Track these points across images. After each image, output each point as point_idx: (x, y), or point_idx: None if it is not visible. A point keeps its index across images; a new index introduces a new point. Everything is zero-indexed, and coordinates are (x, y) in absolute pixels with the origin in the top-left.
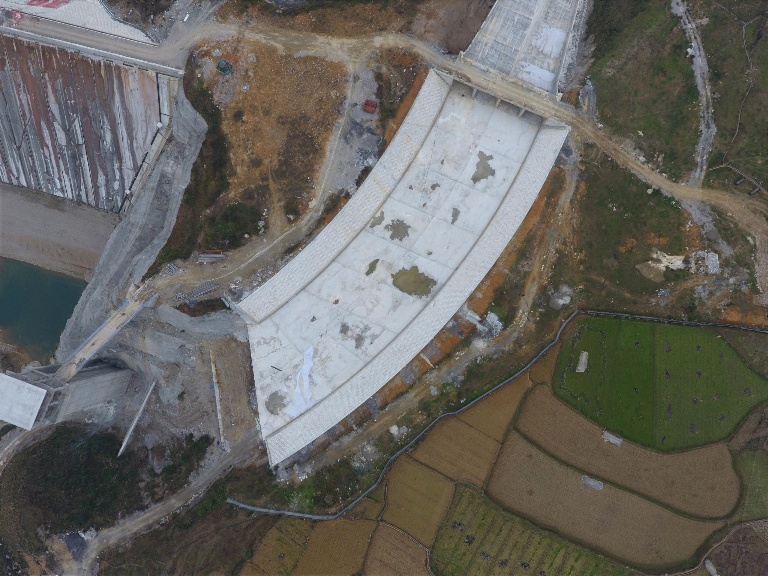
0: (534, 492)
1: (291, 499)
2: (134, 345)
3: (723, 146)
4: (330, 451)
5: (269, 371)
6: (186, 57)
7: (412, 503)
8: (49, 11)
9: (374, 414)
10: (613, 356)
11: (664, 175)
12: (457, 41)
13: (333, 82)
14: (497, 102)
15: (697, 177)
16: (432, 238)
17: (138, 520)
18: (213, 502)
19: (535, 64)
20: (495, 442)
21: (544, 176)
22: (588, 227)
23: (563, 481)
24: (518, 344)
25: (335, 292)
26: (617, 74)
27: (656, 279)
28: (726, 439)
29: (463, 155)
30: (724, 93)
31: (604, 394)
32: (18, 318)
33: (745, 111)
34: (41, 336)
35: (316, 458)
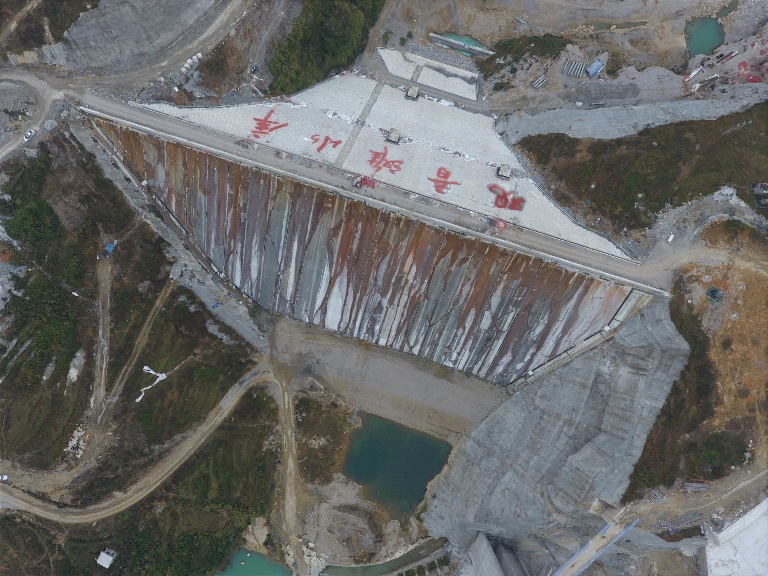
0: None
1: None
2: (553, 540)
3: None
4: None
5: None
6: (671, 278)
7: None
8: (519, 215)
9: None
10: None
11: None
12: None
13: None
14: None
15: None
16: None
17: None
18: None
19: None
20: None
21: None
22: None
23: None
24: None
25: None
26: None
27: None
28: None
29: None
30: None
31: None
32: (376, 473)
33: None
34: (399, 494)
35: None
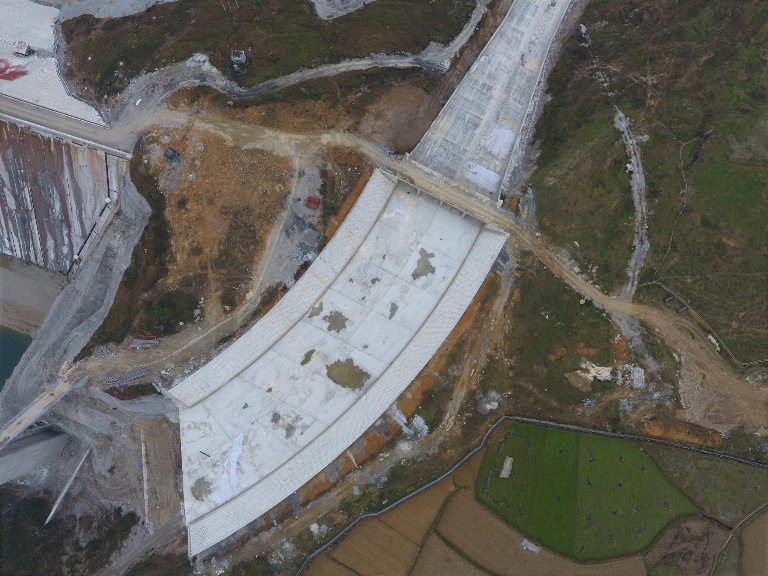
0: None
1: None
2: (68, 415)
3: (655, 263)
4: (249, 546)
5: (197, 456)
6: (135, 141)
7: None
8: (3, 83)
9: (295, 511)
10: (537, 463)
11: (597, 287)
12: (405, 140)
13: (278, 176)
14: (440, 203)
15: (628, 291)
16: (369, 332)
17: None
18: None
19: (482, 165)
20: (414, 545)
21: (480, 281)
22: (520, 334)
23: None
24: (443, 448)
25: (269, 380)
26: (558, 183)
27: (584, 388)
28: (643, 552)
29: (405, 251)
30: (659, 211)
31: (526, 501)
32: None
33: (678, 230)
34: None
35: (234, 553)
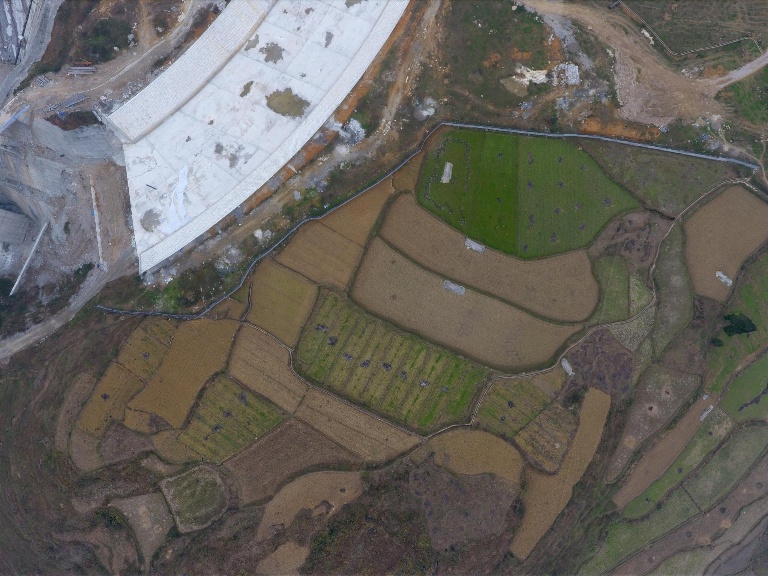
0: (397, 297)
1: (157, 301)
2: (21, 179)
3: None
4: (195, 254)
5: (144, 189)
6: None
7: (276, 305)
8: None
9: (239, 218)
10: (477, 167)
11: None
12: None
13: None
14: None
15: None
16: (306, 61)
17: (18, 341)
18: (86, 312)
19: None
20: (358, 246)
21: None
22: (453, 42)
23: (426, 286)
24: (381, 151)
25: (210, 113)
26: None
27: (520, 94)
28: (586, 246)
29: None
30: None
31: (468, 204)
32: None
33: None
34: None
35: (181, 261)
